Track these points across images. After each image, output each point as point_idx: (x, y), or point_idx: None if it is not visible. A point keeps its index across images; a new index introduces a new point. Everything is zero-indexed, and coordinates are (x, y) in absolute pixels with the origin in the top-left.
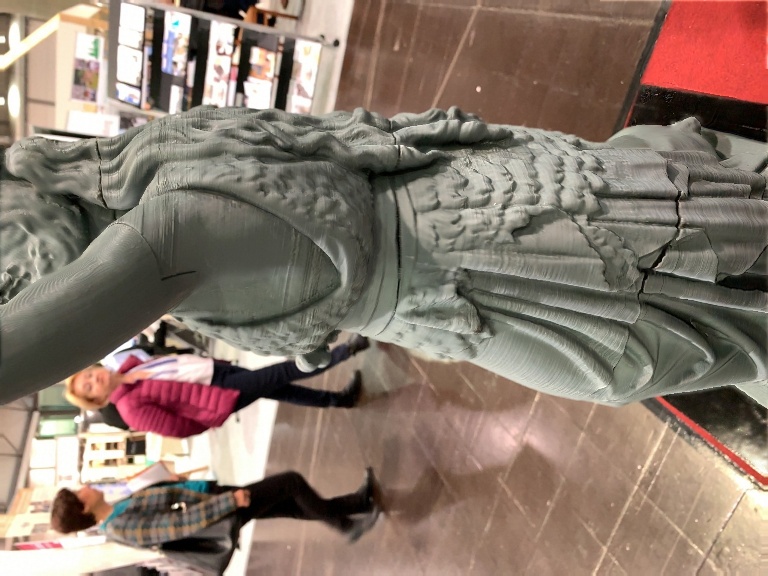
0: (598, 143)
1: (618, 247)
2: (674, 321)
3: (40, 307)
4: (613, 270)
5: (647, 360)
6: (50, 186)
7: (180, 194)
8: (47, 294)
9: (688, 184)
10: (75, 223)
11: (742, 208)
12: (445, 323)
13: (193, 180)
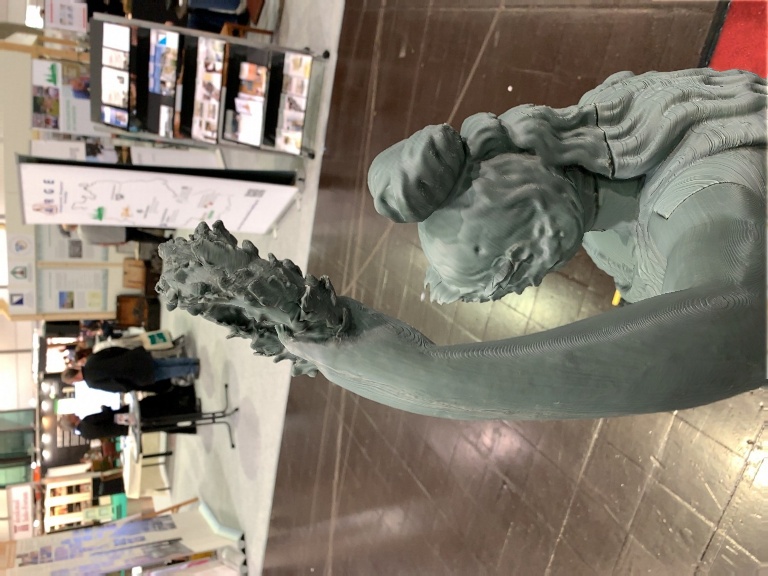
0: None
1: None
2: None
3: (757, 269)
4: None
5: None
6: (557, 157)
7: (744, 151)
8: (747, 256)
9: None
10: (578, 196)
11: None
12: None
13: (760, 135)
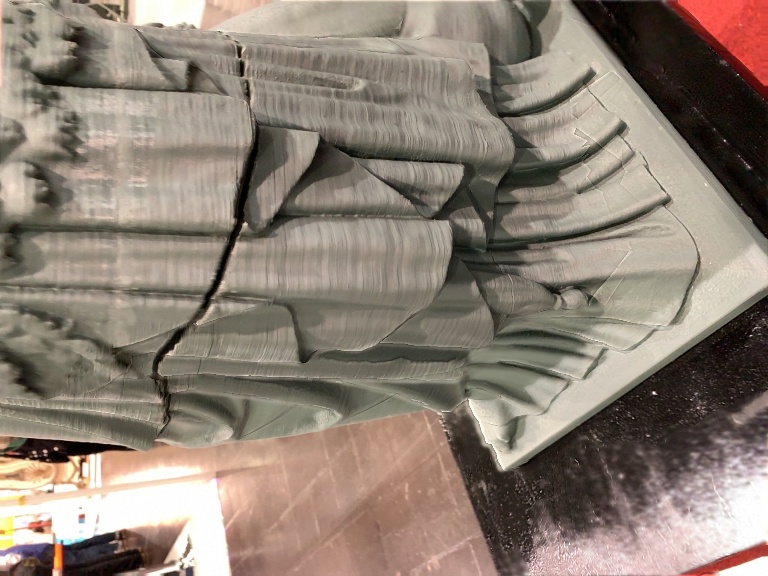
0: (136, 67)
1: (53, 338)
2: (255, 387)
3: None
4: (55, 367)
5: (220, 421)
6: None
7: None
8: None
9: (293, 190)
10: None
11: (379, 253)
12: None
13: None
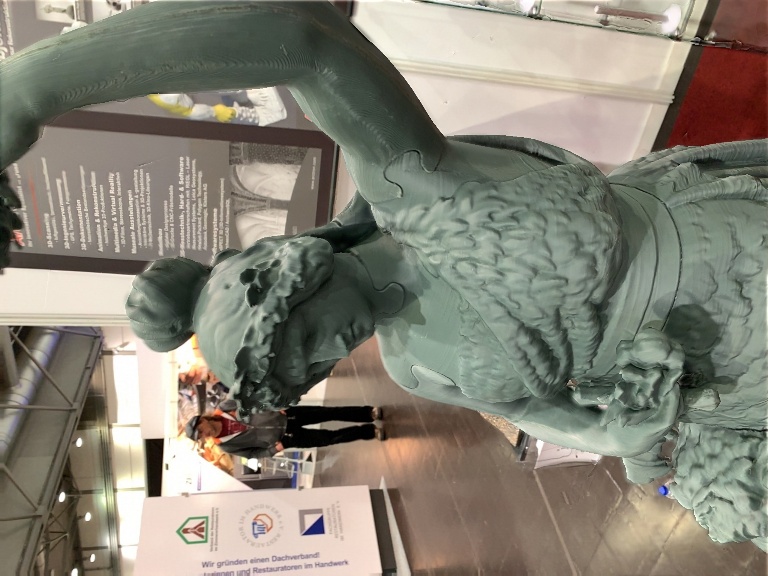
0: None
1: None
2: None
3: None
4: None
5: None
6: None
7: None
8: None
9: None
10: None
11: None
12: (716, 182)
13: None
